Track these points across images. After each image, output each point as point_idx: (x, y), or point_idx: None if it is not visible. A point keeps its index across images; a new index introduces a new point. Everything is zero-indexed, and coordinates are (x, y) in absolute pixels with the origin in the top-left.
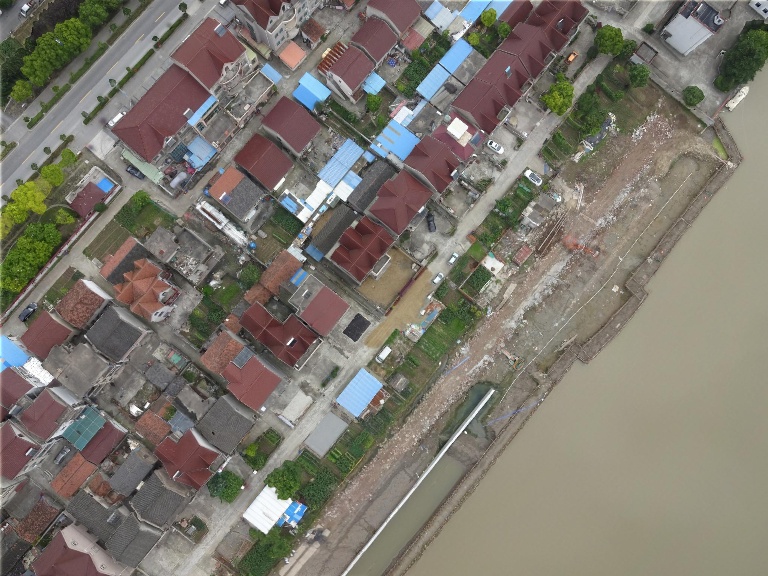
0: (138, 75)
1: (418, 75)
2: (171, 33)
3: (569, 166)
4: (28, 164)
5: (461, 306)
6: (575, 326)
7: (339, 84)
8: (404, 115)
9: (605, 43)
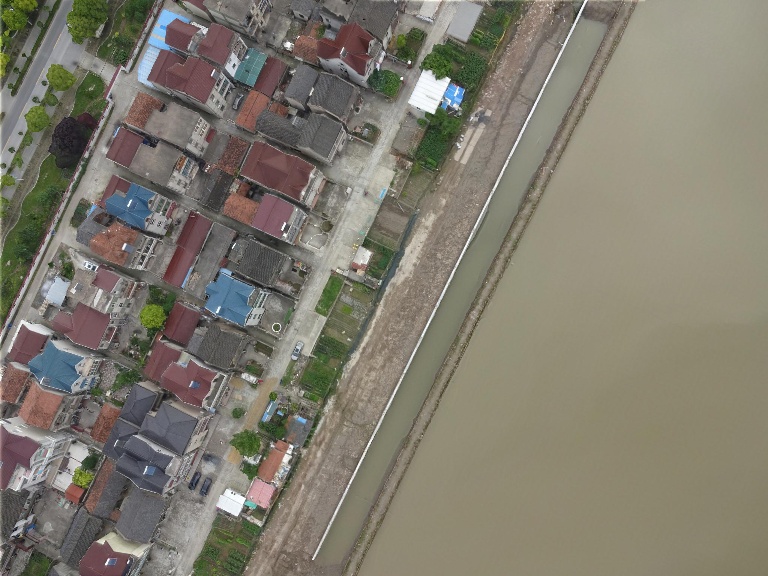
0: None
1: None
2: None
3: None
4: None
5: None
6: None
7: None
8: None
9: None
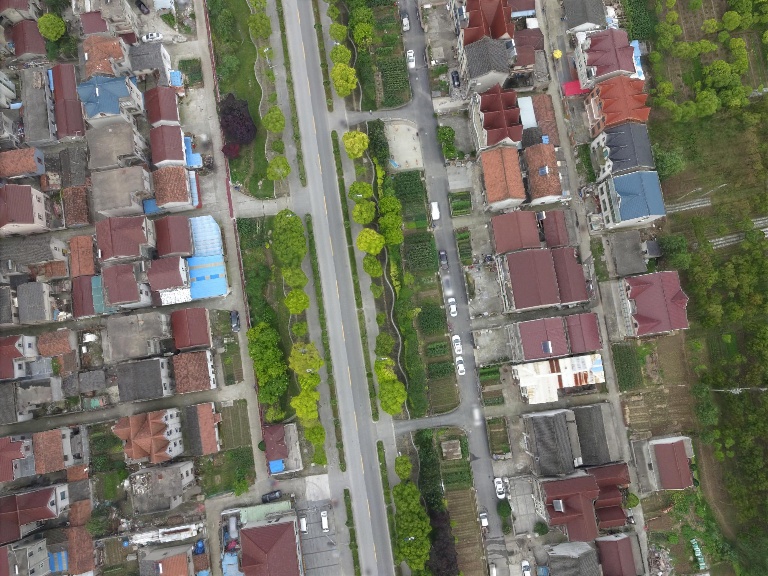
0: (352, 569)
1: None
2: None
3: None
4: (351, 416)
5: None
6: None
7: None
8: None
9: None
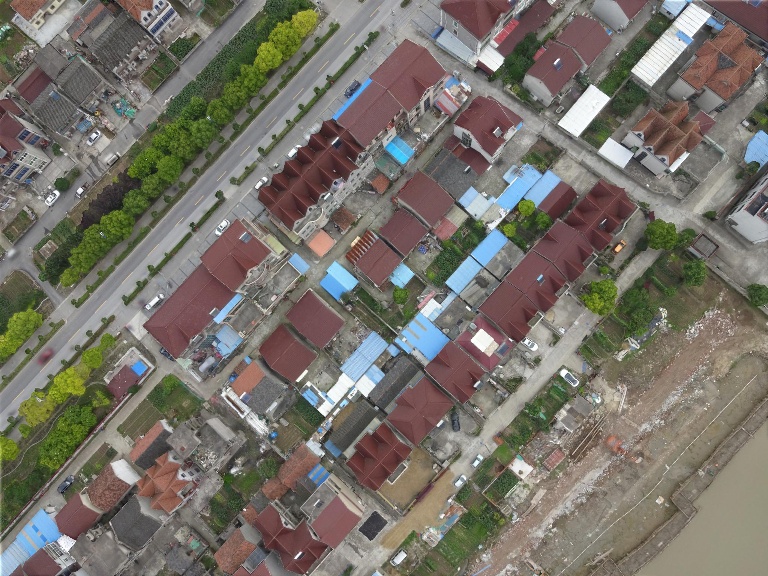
0: (176, 257)
1: (449, 263)
2: (208, 217)
3: (611, 364)
4: (74, 341)
5: (484, 511)
6: (611, 538)
7: None
8: (432, 308)
9: (655, 240)
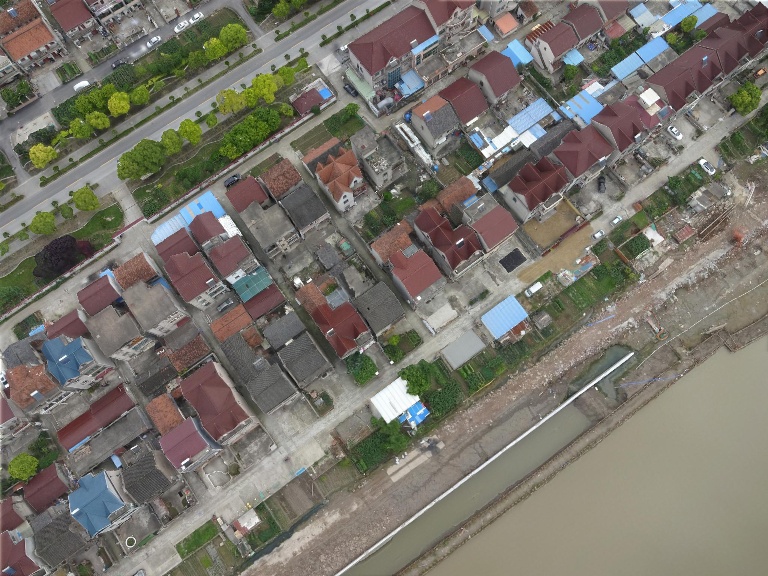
0: (373, 18)
1: (613, 61)
2: None
3: (743, 166)
4: (267, 67)
5: (616, 266)
6: (726, 315)
7: (543, 52)
8: (595, 88)
9: None
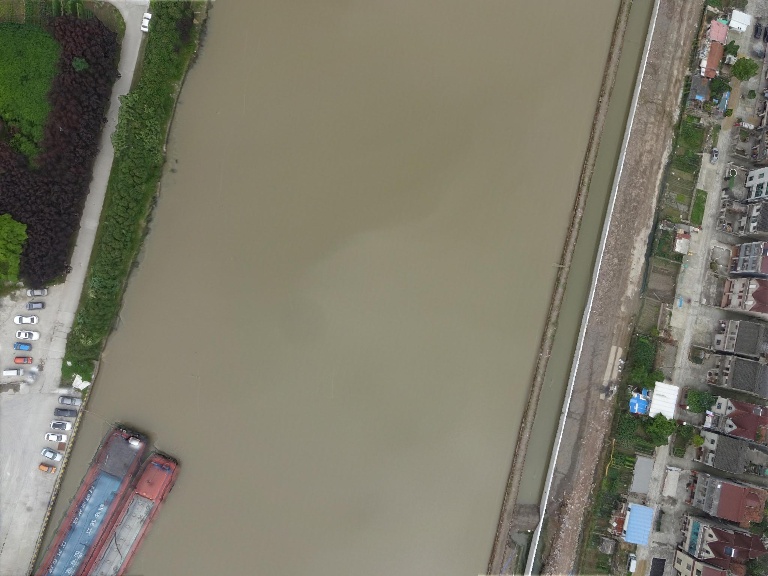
0: None
1: None
2: None
3: None
4: None
5: None
6: None
7: None
8: None
9: None
